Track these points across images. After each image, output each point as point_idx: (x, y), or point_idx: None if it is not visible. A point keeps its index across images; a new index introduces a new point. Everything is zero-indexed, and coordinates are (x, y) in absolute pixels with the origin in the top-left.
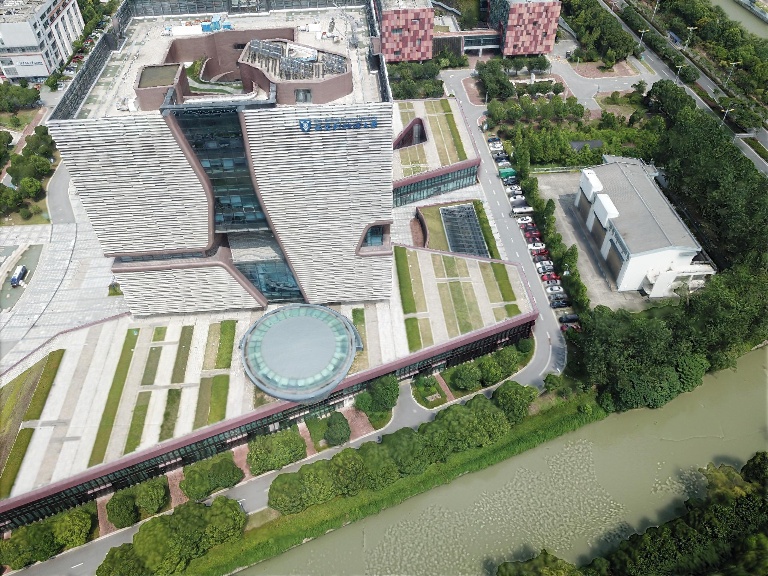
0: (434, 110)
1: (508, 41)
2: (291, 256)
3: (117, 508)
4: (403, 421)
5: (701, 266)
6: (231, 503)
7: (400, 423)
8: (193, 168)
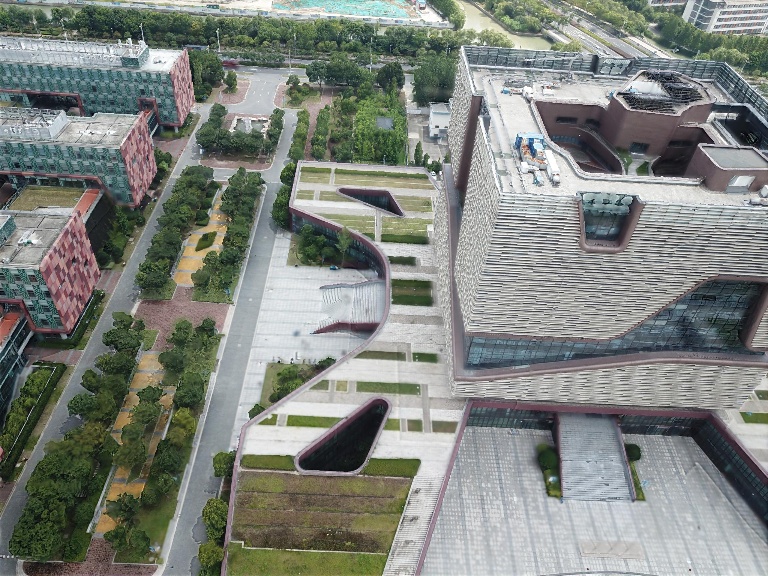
0: (322, 178)
1: (179, 110)
2: None
3: None
4: None
5: None
6: None
7: None
8: None
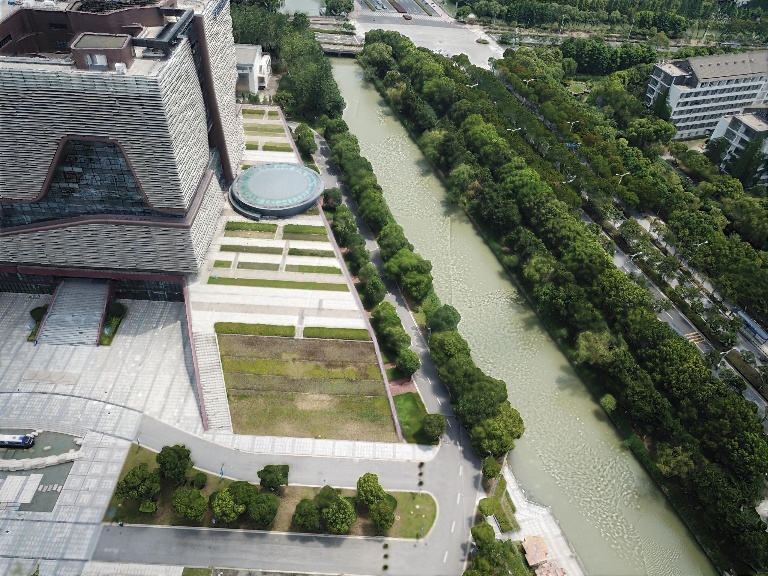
0: None
1: None
2: (225, 139)
3: (380, 280)
4: (326, 184)
5: (264, 57)
6: (387, 227)
7: (327, 185)
8: (198, 81)
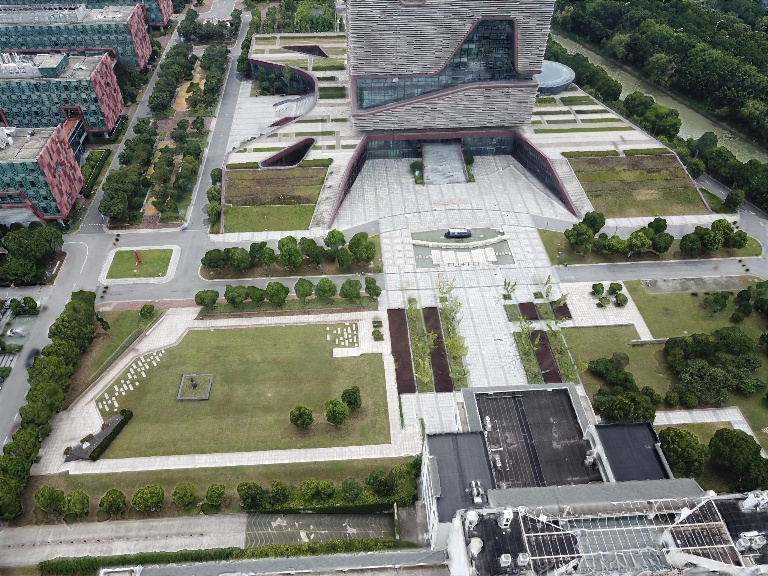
0: (271, 42)
1: (163, 12)
2: None
3: None
4: None
5: None
6: None
7: None
8: None
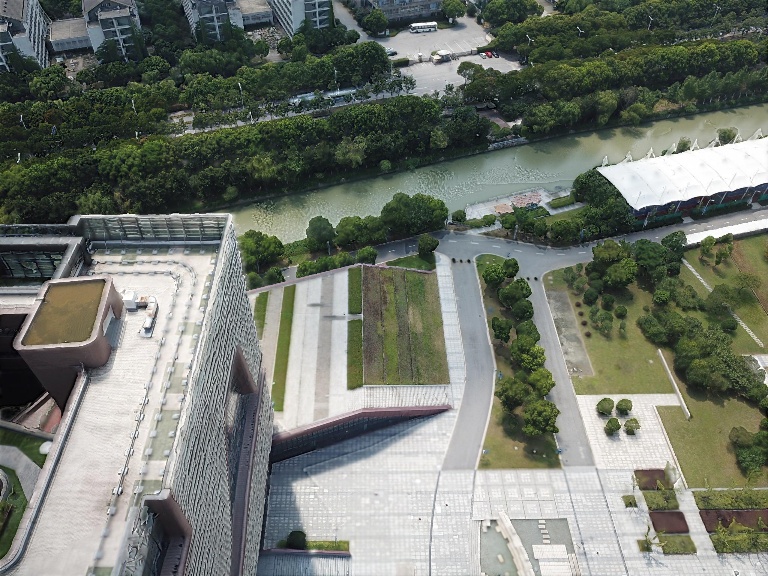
0: None
1: None
2: None
3: None
4: None
5: None
6: None
7: None
8: None
